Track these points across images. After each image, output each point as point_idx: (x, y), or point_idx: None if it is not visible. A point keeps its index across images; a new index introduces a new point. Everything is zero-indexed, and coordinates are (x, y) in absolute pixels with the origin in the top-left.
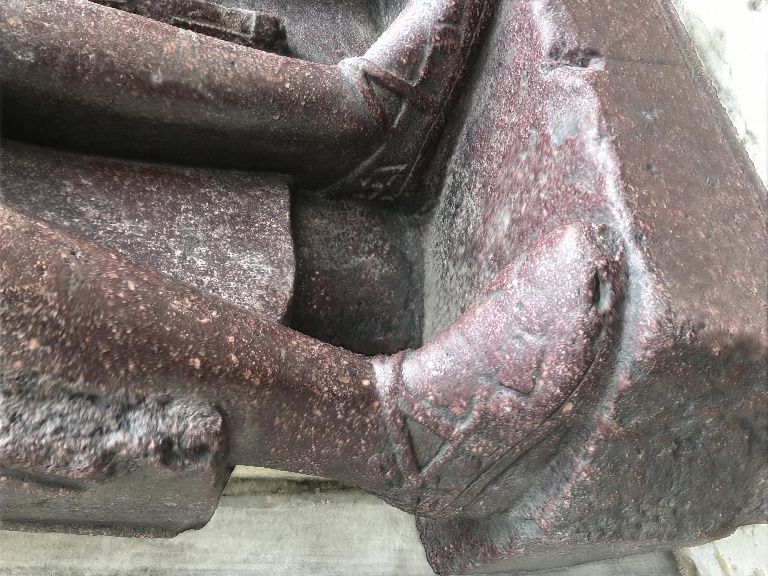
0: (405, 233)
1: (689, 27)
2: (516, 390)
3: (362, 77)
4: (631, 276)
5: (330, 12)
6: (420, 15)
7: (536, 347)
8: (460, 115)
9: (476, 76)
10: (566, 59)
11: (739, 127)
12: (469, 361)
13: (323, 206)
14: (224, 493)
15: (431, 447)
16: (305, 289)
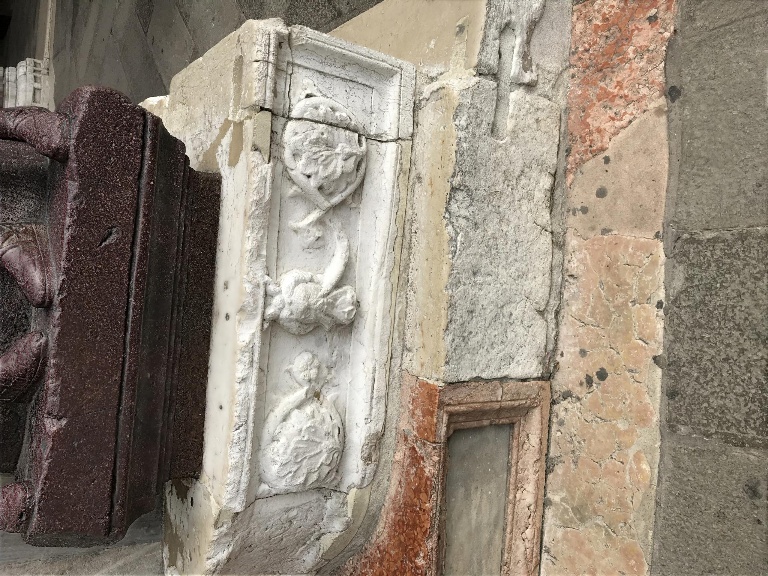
0: (19, 405)
1: (215, 294)
2: (1, 526)
3: None
4: (34, 512)
5: (3, 280)
6: (10, 369)
7: (5, 521)
8: (34, 389)
9: (38, 384)
10: (53, 416)
11: (210, 360)
12: None
13: None
14: None
15: None
16: None
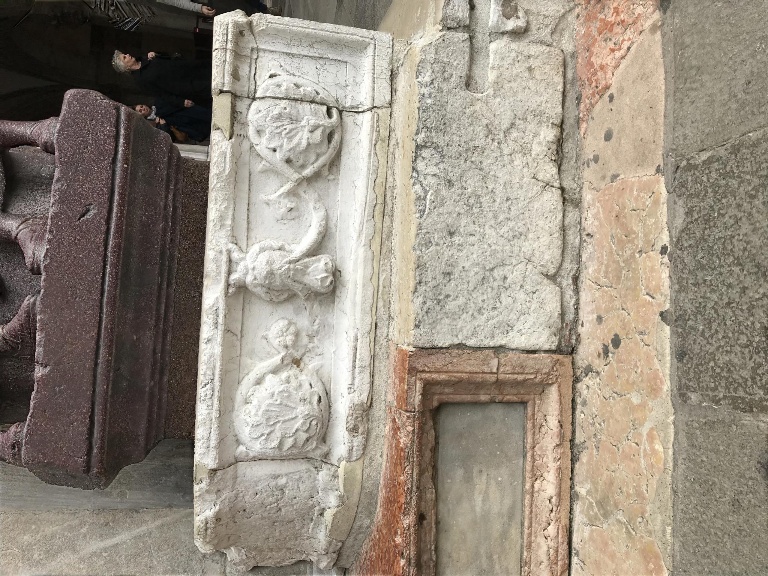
0: None
1: None
2: None
3: (2, 338)
4: None
5: None
6: (15, 326)
7: None
8: None
9: None
10: (41, 364)
11: (200, 328)
12: (2, 447)
13: (12, 358)
14: (4, 427)
15: (5, 458)
16: (7, 384)
